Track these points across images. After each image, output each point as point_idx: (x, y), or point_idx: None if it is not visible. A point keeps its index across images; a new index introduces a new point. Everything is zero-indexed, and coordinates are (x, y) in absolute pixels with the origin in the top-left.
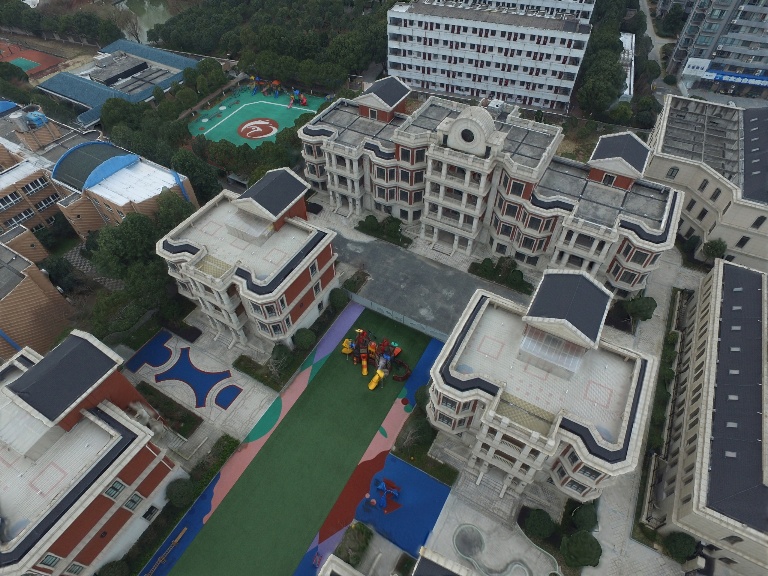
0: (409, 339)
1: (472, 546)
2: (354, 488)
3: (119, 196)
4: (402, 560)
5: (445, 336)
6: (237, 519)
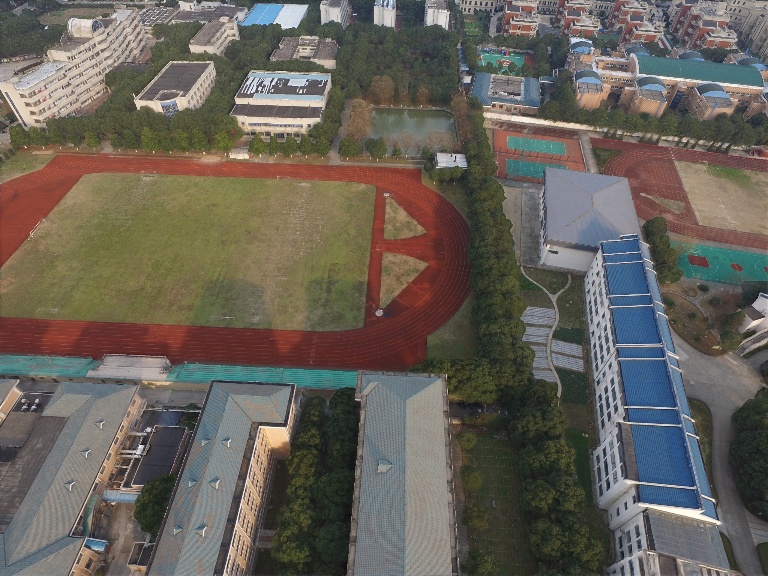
0: None
1: None
2: (601, 33)
3: None
4: (606, 29)
5: None
6: None
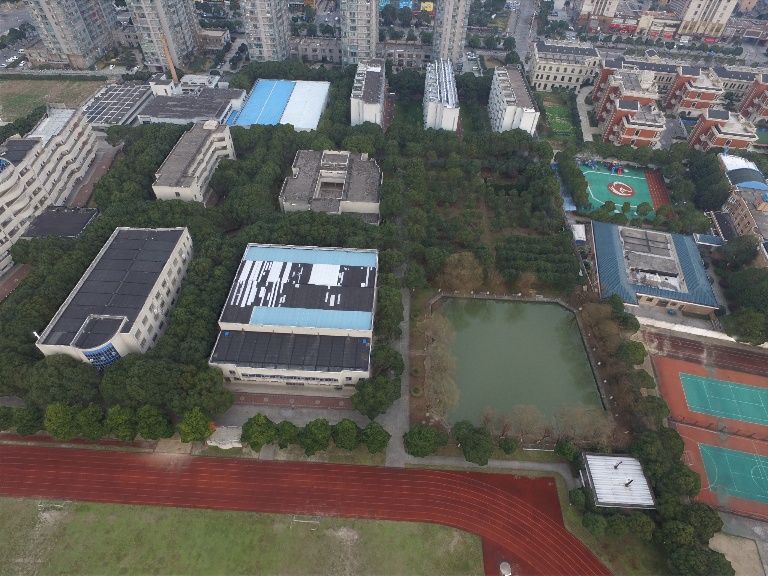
0: None
1: None
2: None
3: (750, 167)
4: None
5: None
6: (765, 141)
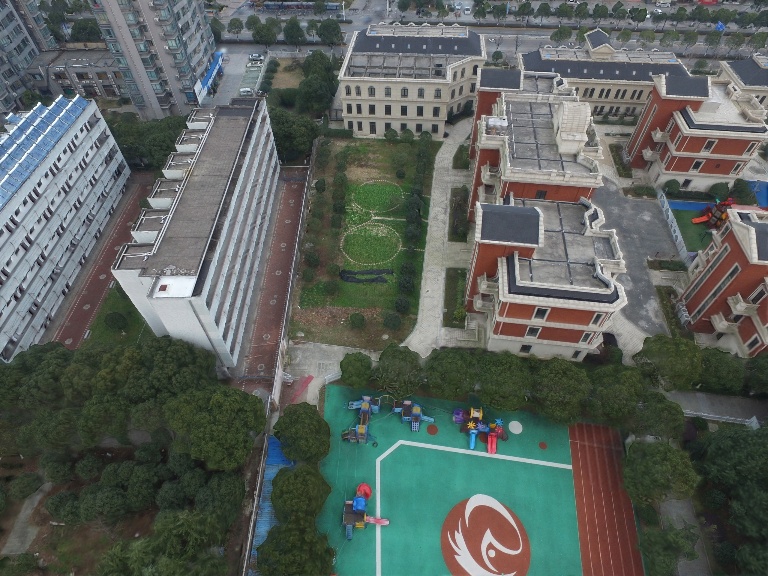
0: (679, 218)
1: (757, 170)
2: None
3: None
4: None
5: (655, 202)
6: None
